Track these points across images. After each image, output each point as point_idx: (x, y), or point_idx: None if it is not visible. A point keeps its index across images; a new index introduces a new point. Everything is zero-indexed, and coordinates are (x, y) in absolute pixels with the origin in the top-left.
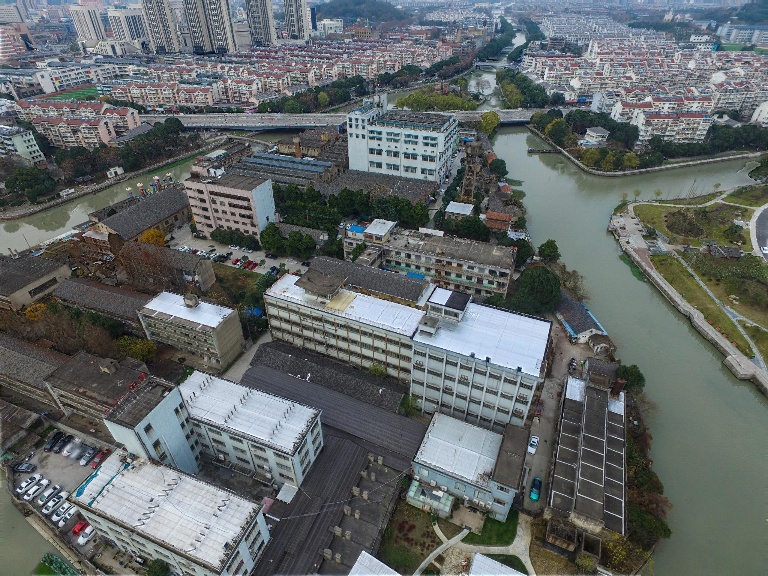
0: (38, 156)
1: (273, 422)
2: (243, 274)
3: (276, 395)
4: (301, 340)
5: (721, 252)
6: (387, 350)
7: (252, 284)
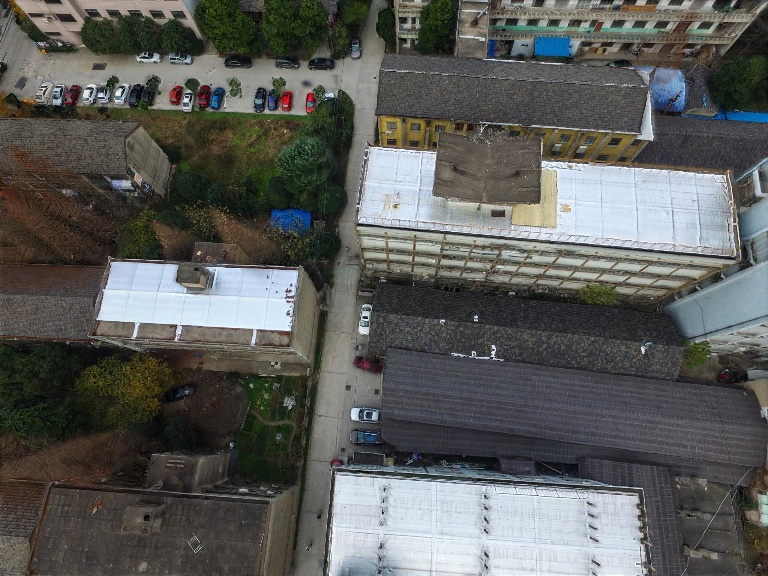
0: None
1: (573, 555)
2: (210, 125)
3: (534, 481)
4: (431, 269)
5: None
6: (642, 273)
7: (242, 145)
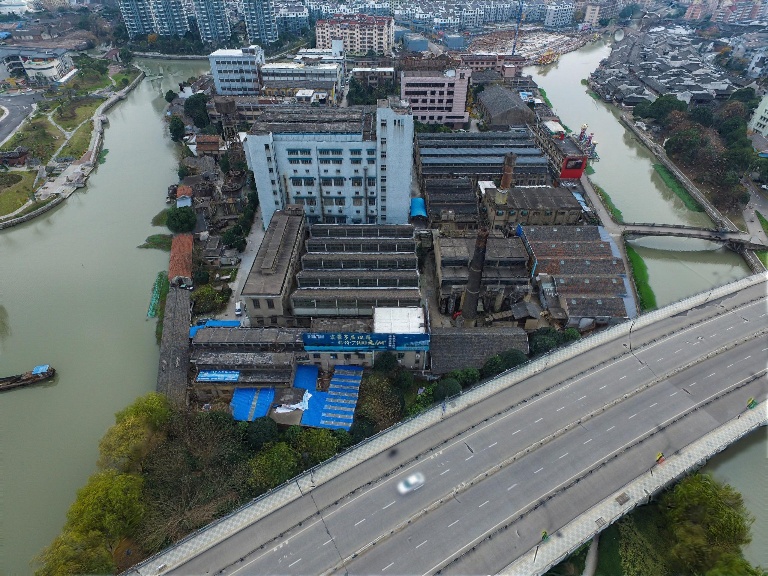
0: (763, 126)
1: None
2: None
3: None
4: None
5: (19, 148)
6: None
7: None
